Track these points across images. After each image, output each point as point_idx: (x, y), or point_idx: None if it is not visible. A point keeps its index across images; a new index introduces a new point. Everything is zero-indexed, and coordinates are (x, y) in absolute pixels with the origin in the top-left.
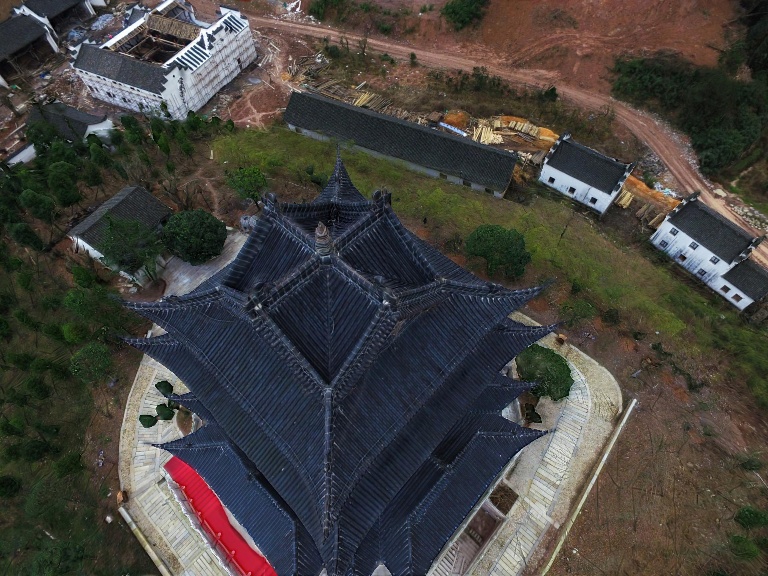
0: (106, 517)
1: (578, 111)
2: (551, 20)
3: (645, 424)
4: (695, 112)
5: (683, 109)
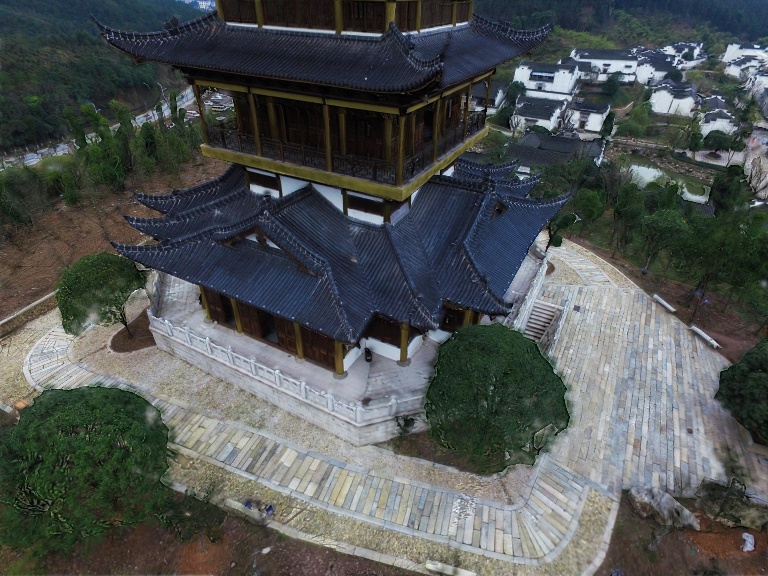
0: None
1: None
2: None
3: None
4: None
5: None
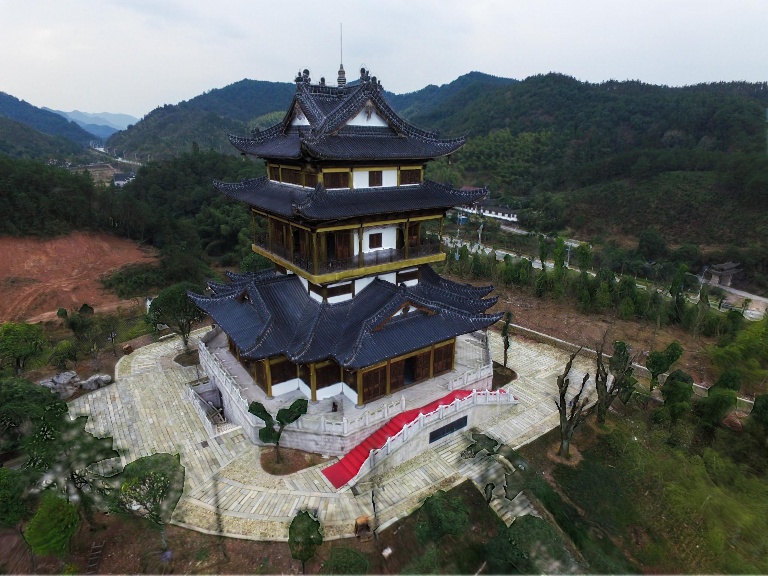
0: (382, 555)
1: (120, 308)
2: (11, 285)
3: None
4: (185, 278)
5: (175, 283)
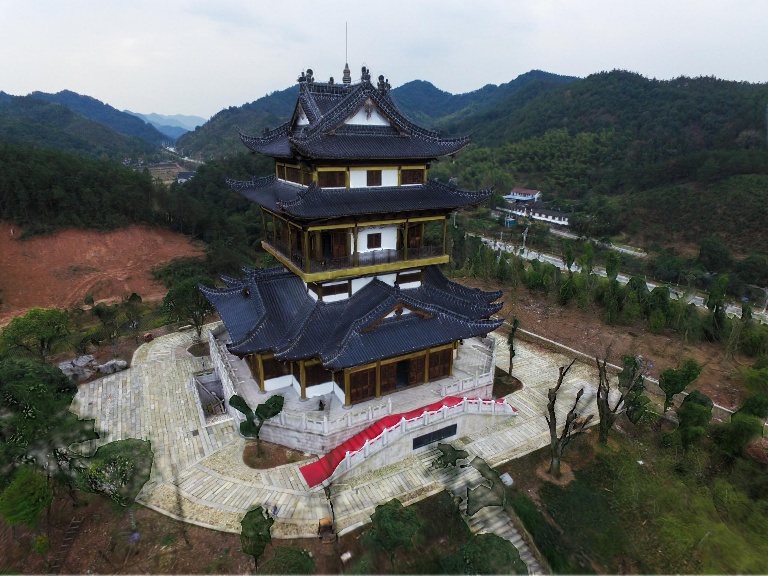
0: (341, 559)
1: None
2: (73, 273)
3: None
4: (228, 272)
5: None
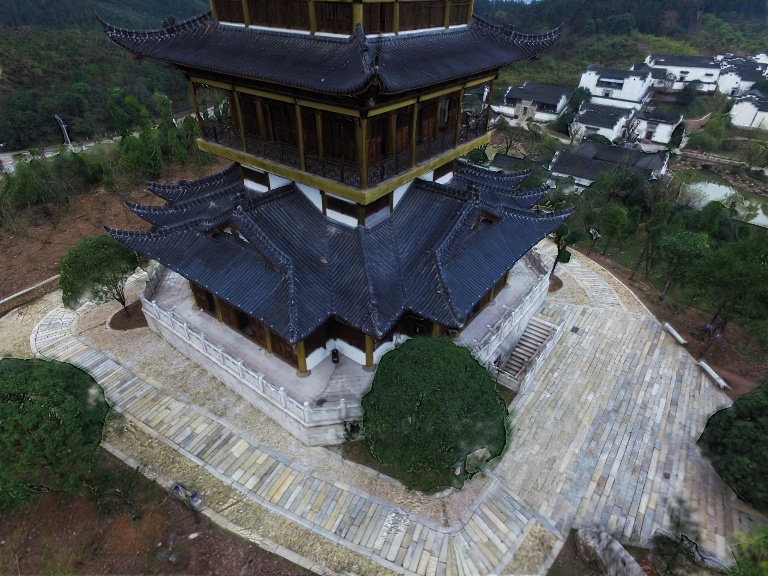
0: None
1: None
2: None
3: (2, 287)
4: None
5: None
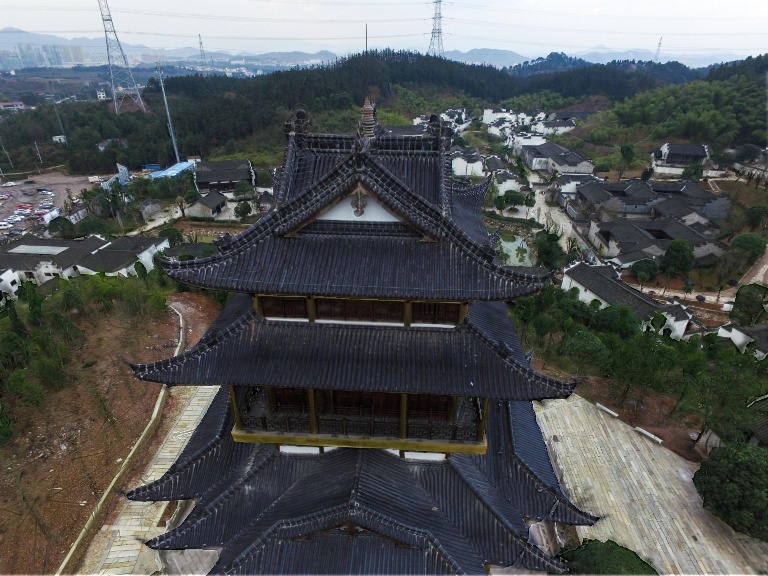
0: None
1: None
2: None
3: None
4: None
5: None
